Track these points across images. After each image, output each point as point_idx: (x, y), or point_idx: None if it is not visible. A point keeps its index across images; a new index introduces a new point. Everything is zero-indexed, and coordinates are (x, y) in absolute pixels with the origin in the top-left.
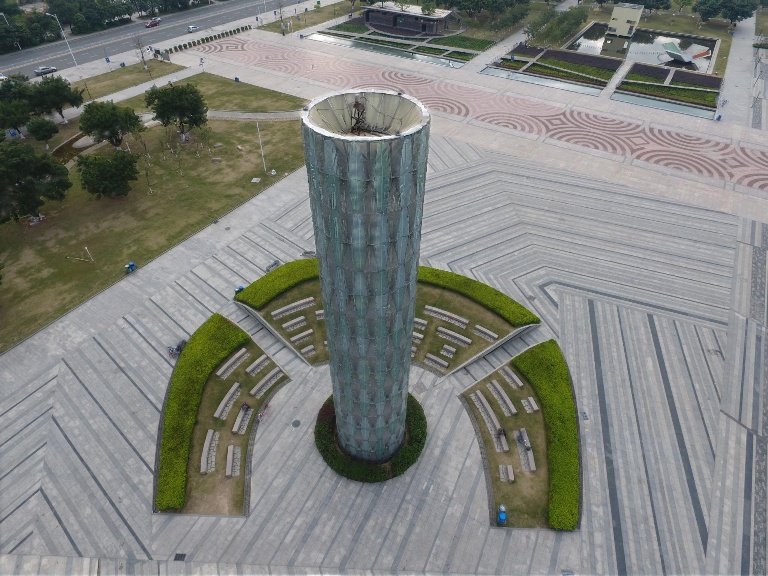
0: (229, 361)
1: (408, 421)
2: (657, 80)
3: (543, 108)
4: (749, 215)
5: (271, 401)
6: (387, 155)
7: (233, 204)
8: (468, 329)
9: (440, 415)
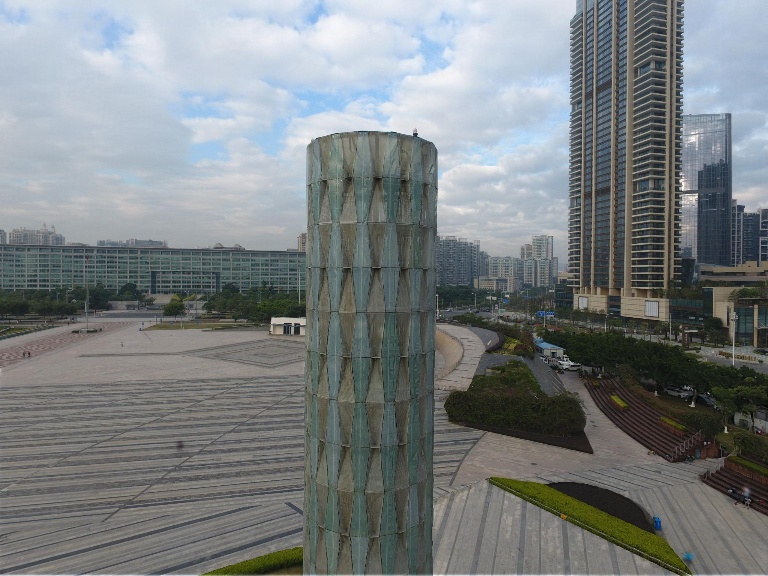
0: None
1: None
2: None
3: None
4: None
5: None
6: None
7: None
8: None
9: None
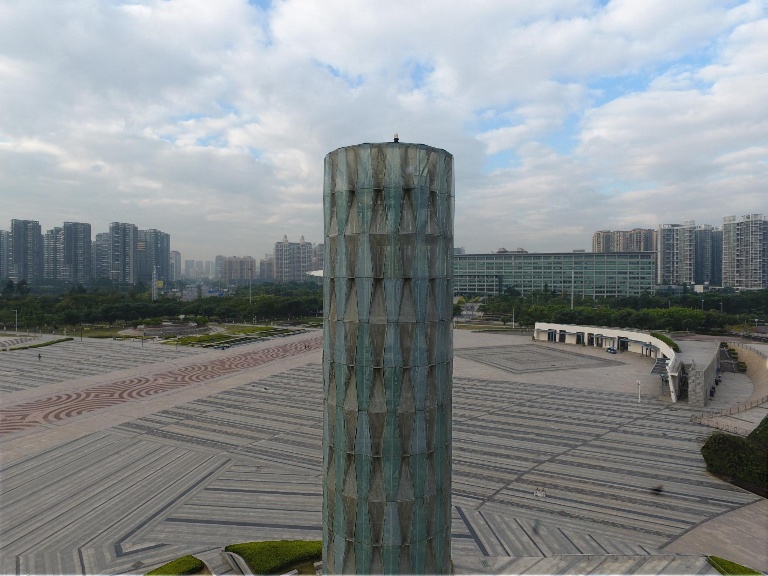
0: None
1: None
2: None
3: None
4: (102, 427)
5: None
6: None
7: None
8: None
9: None
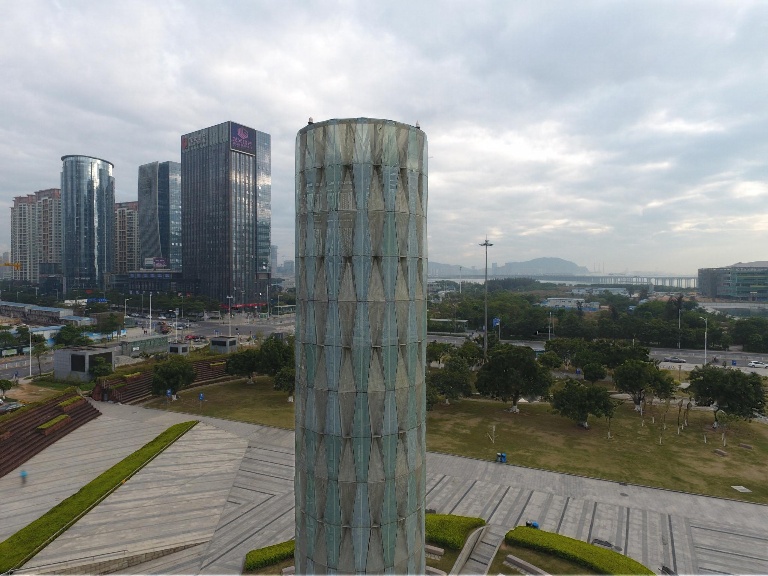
0: None
1: None
2: None
3: None
4: None
5: None
6: None
7: (669, 486)
8: None
9: None
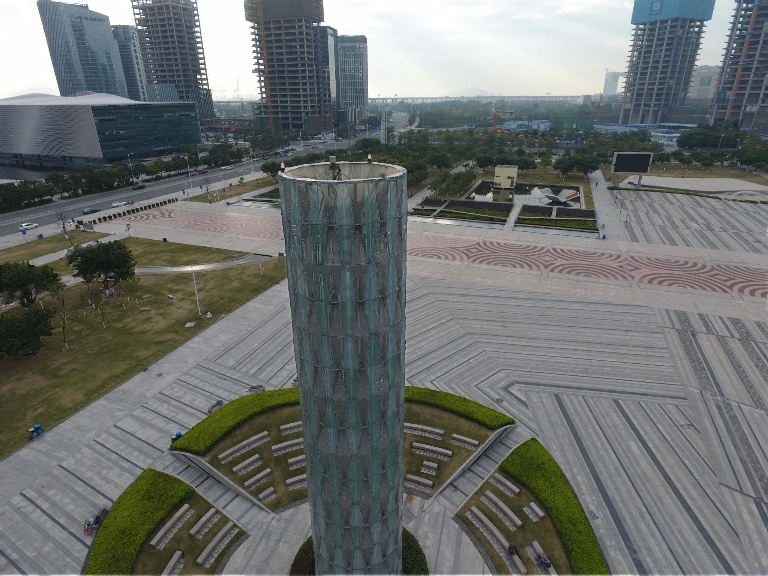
0: (167, 523)
1: (403, 558)
2: (545, 215)
3: (459, 241)
4: (660, 305)
5: (225, 568)
6: (374, 197)
7: (165, 350)
8: (445, 440)
9: (438, 545)
